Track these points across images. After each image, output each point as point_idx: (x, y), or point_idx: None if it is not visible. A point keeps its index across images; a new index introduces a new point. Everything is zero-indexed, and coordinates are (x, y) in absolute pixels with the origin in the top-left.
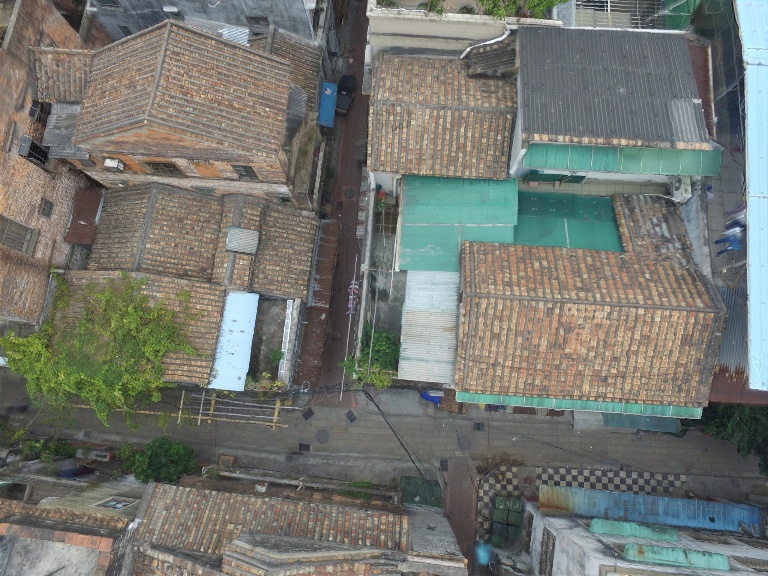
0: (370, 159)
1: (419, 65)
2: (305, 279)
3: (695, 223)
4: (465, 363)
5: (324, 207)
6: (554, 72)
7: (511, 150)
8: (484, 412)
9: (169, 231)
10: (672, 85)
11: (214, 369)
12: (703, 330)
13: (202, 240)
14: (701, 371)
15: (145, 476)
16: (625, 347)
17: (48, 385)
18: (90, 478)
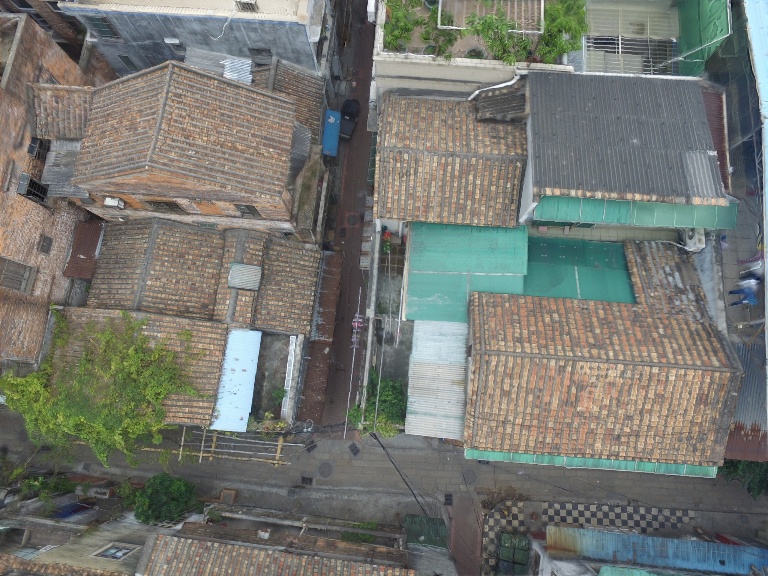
0: (376, 206)
1: (426, 108)
2: (308, 314)
3: (709, 274)
4: (474, 421)
5: (328, 240)
6: (565, 121)
7: (521, 198)
8: None
9: (170, 267)
10: (686, 135)
11: (216, 410)
12: (719, 390)
13: (204, 275)
14: (716, 430)
15: (145, 516)
16: (638, 406)
17: (47, 426)
18: (89, 513)
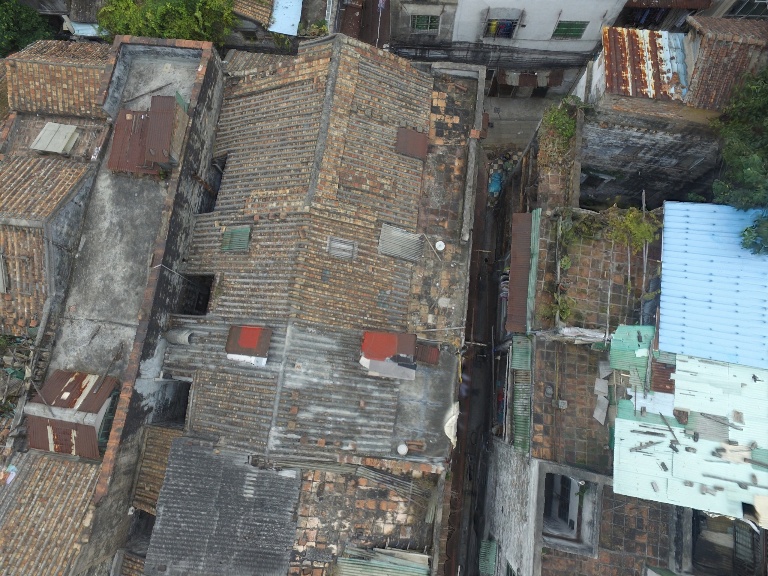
0: None
1: None
2: None
3: None
4: None
5: None
6: None
7: None
8: (493, 113)
9: None
10: None
11: (272, 17)
12: None
13: None
14: None
15: None
16: None
17: (137, 26)
18: None
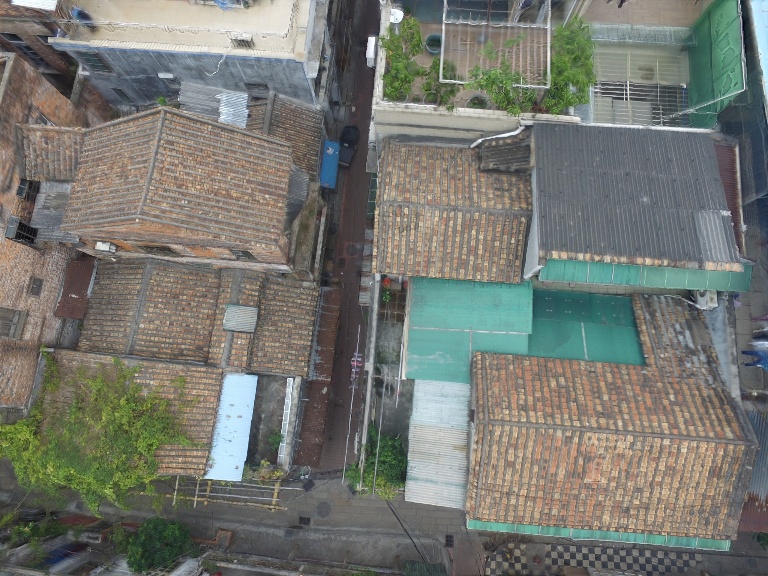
0: (375, 261)
1: (427, 156)
2: (306, 355)
3: (722, 335)
4: (477, 492)
5: (326, 278)
6: (572, 177)
7: (525, 254)
8: None
9: (164, 308)
10: (699, 193)
11: (210, 458)
12: (733, 463)
13: (198, 316)
14: (730, 504)
15: (138, 565)
16: (649, 478)
17: (36, 476)
18: (82, 556)
